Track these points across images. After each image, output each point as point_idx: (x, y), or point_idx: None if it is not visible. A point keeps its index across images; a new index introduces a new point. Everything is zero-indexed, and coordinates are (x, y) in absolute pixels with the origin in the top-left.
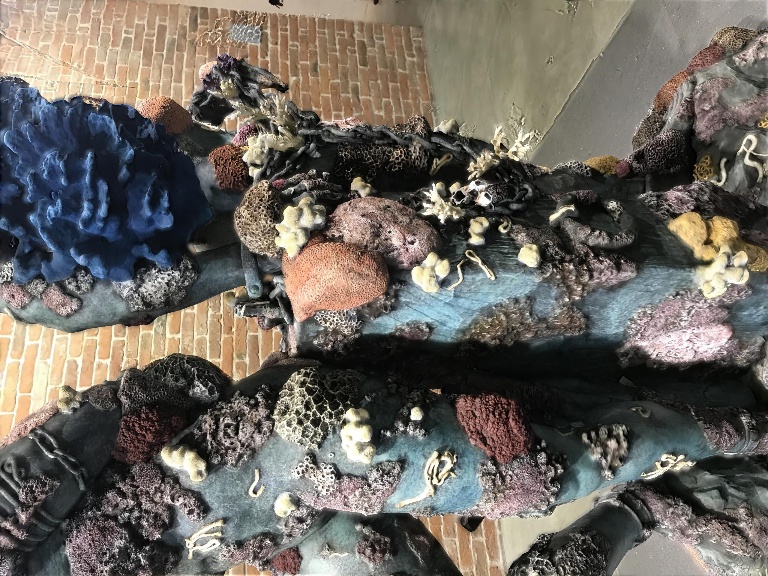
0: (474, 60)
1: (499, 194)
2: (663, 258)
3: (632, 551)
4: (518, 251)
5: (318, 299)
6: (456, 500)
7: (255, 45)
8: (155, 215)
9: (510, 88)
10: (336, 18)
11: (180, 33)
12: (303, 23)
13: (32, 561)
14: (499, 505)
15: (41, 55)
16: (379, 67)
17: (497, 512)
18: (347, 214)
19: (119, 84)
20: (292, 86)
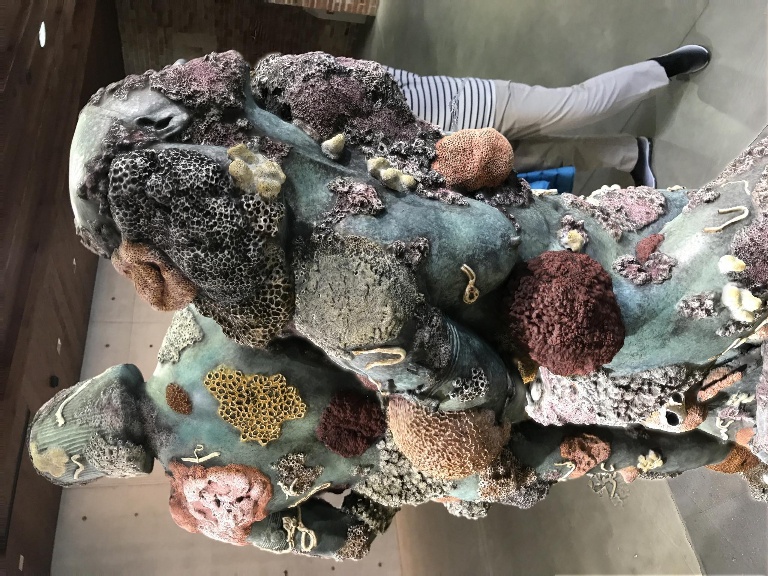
0: None
1: None
2: None
3: None
4: None
5: None
6: None
7: None
8: None
9: None
10: None
11: None
12: None
13: None
14: None
15: None
16: None
17: None
18: None
19: None
20: None
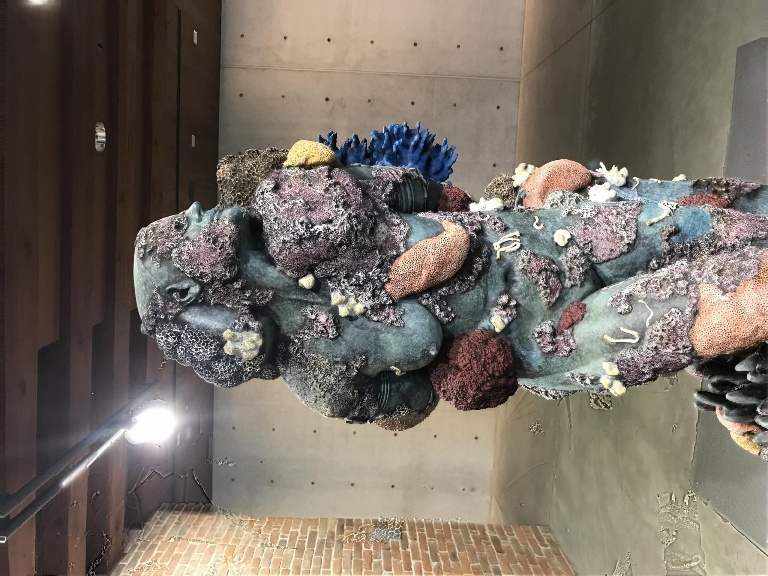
0: (607, 498)
1: None
2: None
3: None
4: None
5: (550, 175)
6: (692, 220)
7: (396, 541)
8: (446, 159)
9: (649, 483)
10: (467, 522)
11: (329, 536)
12: (438, 525)
13: (398, 211)
14: (730, 228)
15: (224, 514)
16: (516, 553)
17: (732, 235)
18: None
19: (273, 571)
20: (434, 568)
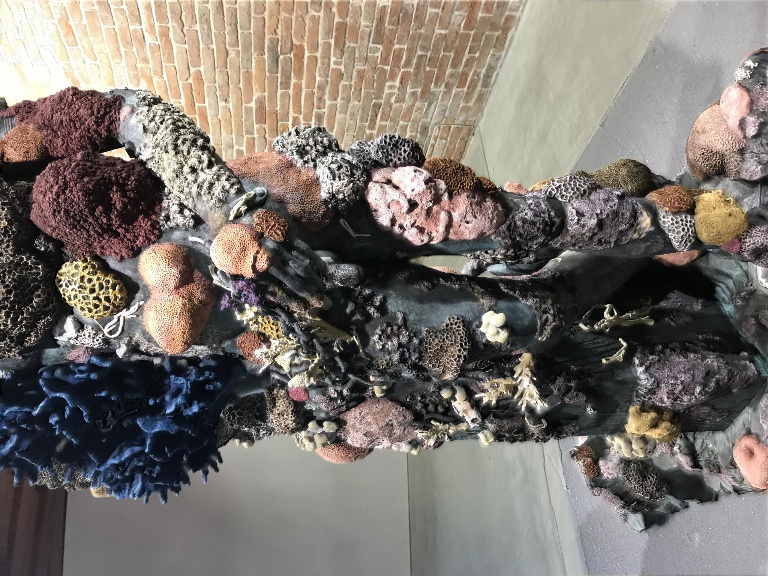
0: None
1: (498, 397)
2: (596, 428)
3: (602, 155)
4: (482, 429)
5: None
6: None
7: None
8: None
9: None
10: None
11: None
12: None
13: None
14: None
15: None
16: None
17: None
18: (354, 429)
19: None
20: None
